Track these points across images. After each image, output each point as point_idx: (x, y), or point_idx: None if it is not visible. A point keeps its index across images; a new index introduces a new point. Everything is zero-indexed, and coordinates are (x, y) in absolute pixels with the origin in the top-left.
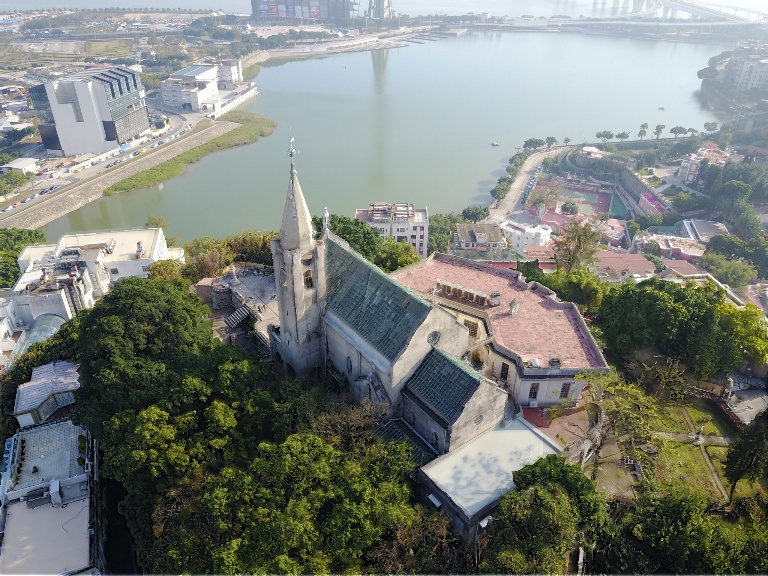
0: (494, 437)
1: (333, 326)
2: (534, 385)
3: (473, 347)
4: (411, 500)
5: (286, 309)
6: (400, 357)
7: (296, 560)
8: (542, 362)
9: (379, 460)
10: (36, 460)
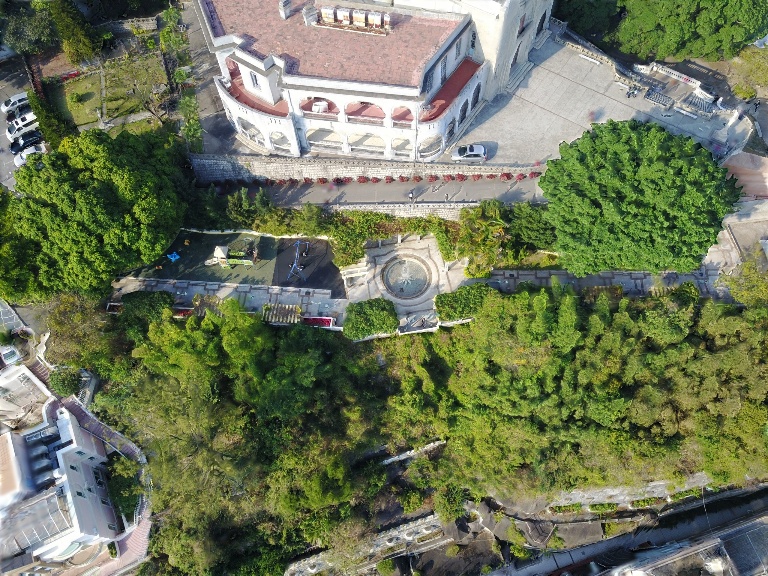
0: None
1: None
2: None
3: None
4: None
5: None
6: None
7: None
8: None
9: None
10: None
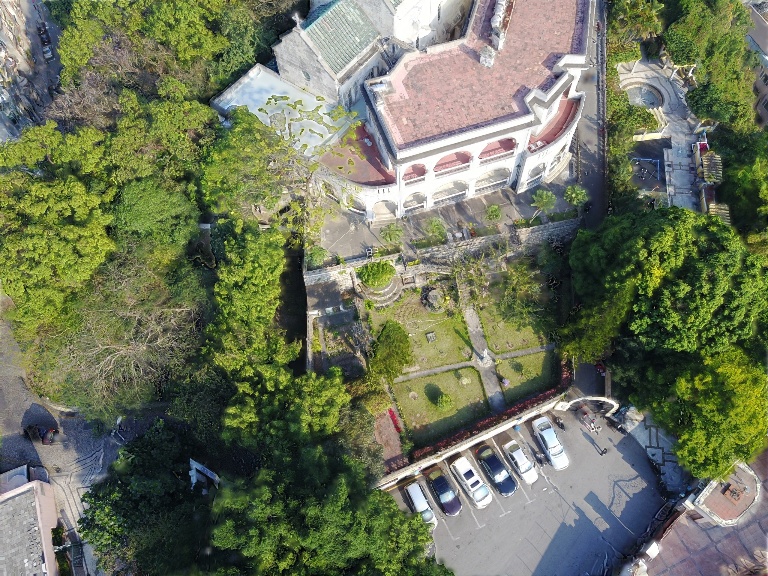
0: None
1: None
2: None
3: (396, 40)
4: None
5: None
6: None
7: (132, 3)
8: (395, 100)
9: None
10: None
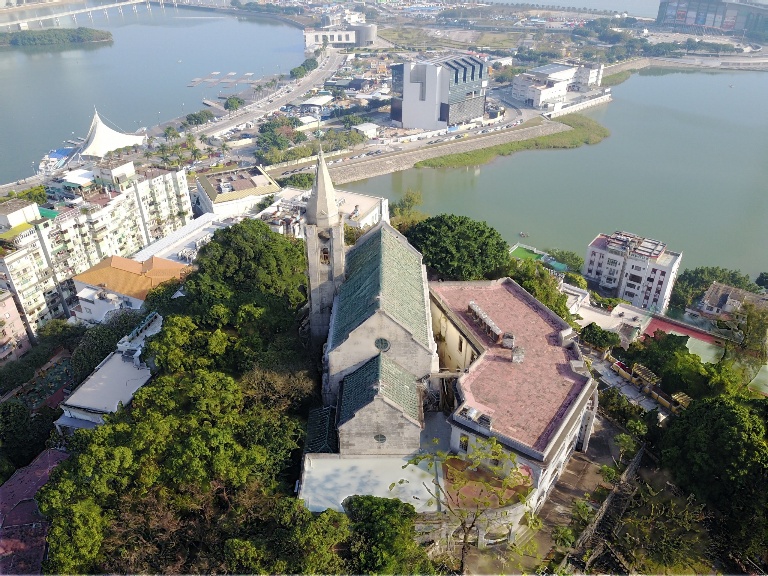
0: (398, 465)
1: (334, 306)
2: (465, 436)
3: (436, 374)
4: (289, 477)
5: None
6: (338, 348)
7: (137, 458)
8: None
9: (270, 426)
10: (152, 332)
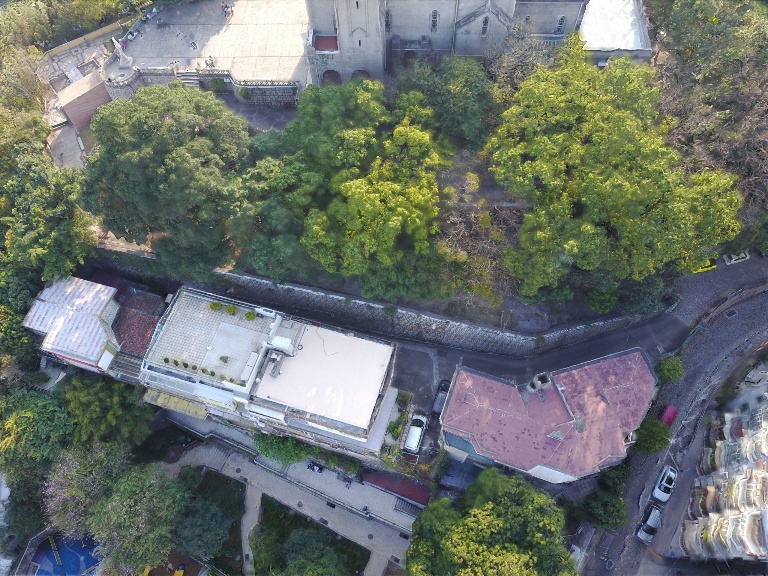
0: None
1: None
2: None
3: None
4: None
5: (355, 0)
6: None
7: None
8: None
9: None
10: (208, 355)
